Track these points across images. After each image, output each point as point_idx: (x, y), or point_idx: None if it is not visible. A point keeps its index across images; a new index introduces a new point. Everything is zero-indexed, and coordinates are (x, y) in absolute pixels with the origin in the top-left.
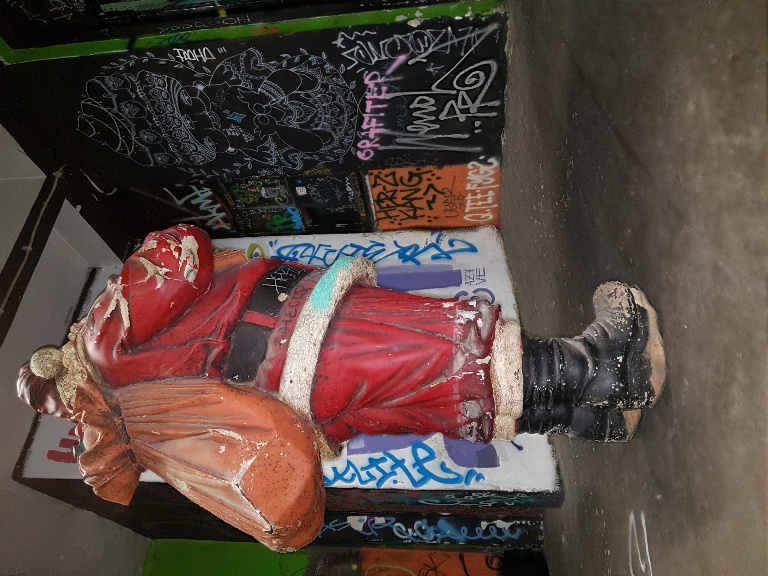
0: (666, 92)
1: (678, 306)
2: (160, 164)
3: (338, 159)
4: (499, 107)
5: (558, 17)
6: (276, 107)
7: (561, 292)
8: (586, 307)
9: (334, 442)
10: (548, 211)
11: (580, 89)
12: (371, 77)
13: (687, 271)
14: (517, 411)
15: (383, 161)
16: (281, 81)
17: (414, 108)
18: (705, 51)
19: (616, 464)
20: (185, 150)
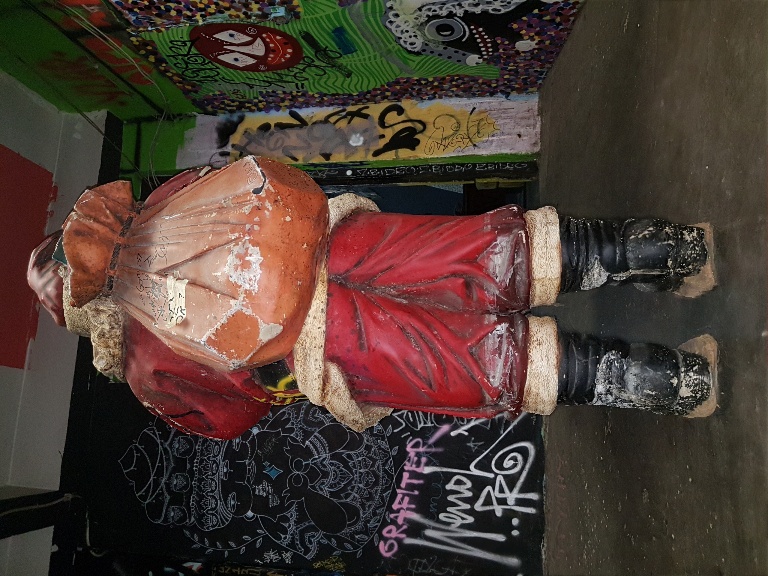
0: (649, 142)
1: (699, 184)
2: (168, 522)
3: (357, 550)
4: (538, 503)
5: (580, 297)
6: (315, 466)
7: (622, 555)
8: (648, 475)
9: (331, 320)
10: (595, 496)
11: (602, 300)
12: (414, 444)
13: (693, 152)
14: (553, 233)
15: (406, 562)
16: (330, 436)
17: (450, 490)
18: (658, 76)
19: (738, 569)
20: (204, 507)
